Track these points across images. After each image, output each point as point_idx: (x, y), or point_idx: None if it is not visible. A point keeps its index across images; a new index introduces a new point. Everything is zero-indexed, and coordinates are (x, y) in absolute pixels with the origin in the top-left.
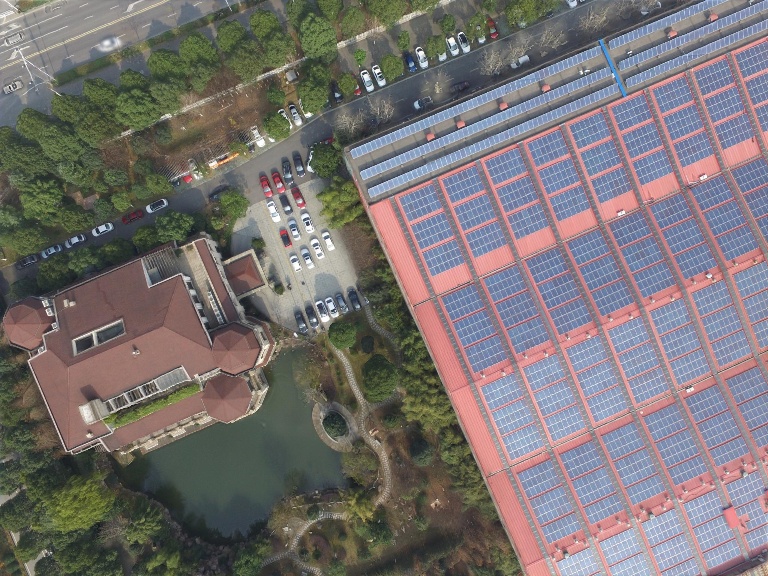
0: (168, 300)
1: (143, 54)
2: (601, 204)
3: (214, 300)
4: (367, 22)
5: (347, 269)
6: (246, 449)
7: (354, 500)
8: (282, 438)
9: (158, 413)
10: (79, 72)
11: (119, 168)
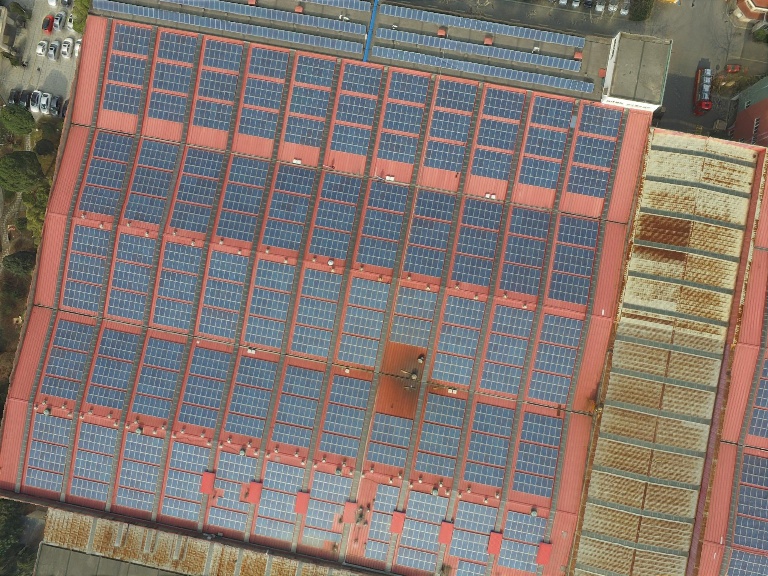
0: None
1: None
2: (285, 142)
3: None
4: None
5: None
6: None
7: None
8: None
9: None
10: None
11: None
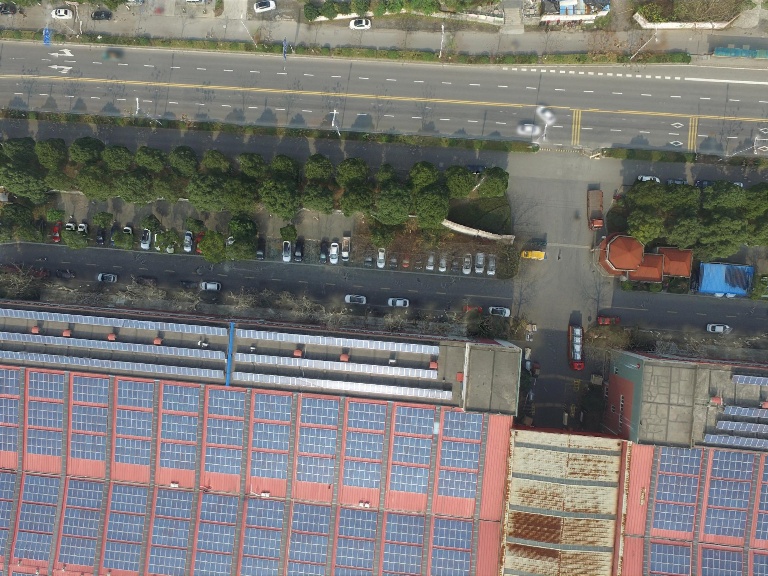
0: None
1: None
2: (161, 467)
3: None
4: (77, 188)
5: None
6: None
7: None
8: None
9: None
10: None
11: None
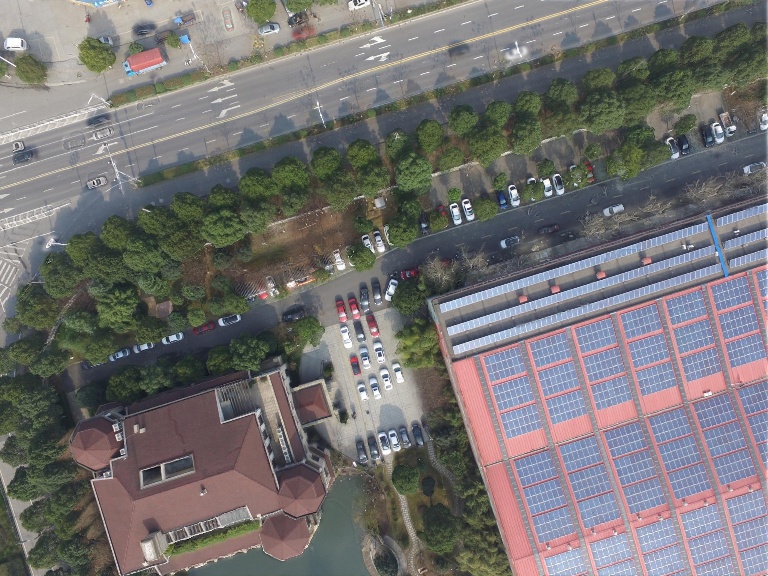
0: (240, 441)
1: (231, 162)
2: (688, 382)
3: (283, 437)
4: (465, 160)
5: (414, 403)
6: (292, 573)
7: None
8: (329, 564)
9: (214, 544)
10: (165, 175)
11: (198, 284)
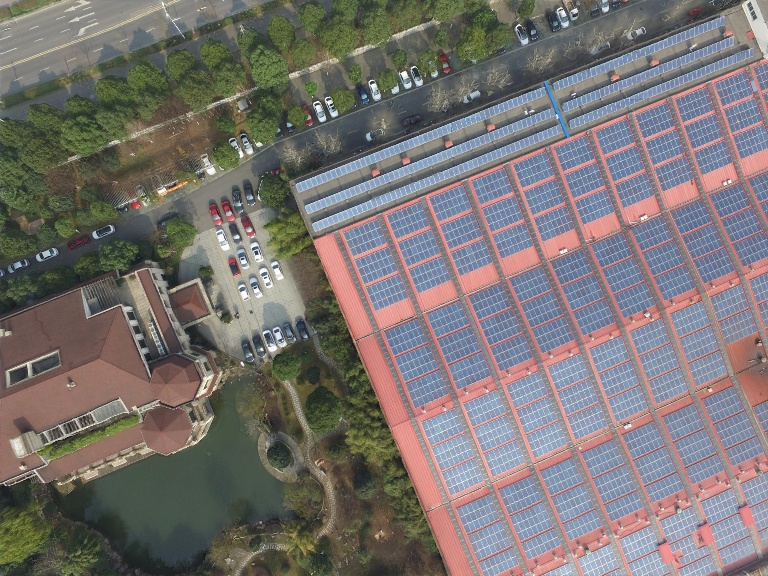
0: (106, 332)
1: (93, 78)
2: (544, 242)
3: (155, 331)
4: (319, 55)
5: (296, 299)
6: (190, 479)
7: (296, 532)
8: (227, 467)
9: (96, 444)
10: (27, 95)
11: (64, 194)
